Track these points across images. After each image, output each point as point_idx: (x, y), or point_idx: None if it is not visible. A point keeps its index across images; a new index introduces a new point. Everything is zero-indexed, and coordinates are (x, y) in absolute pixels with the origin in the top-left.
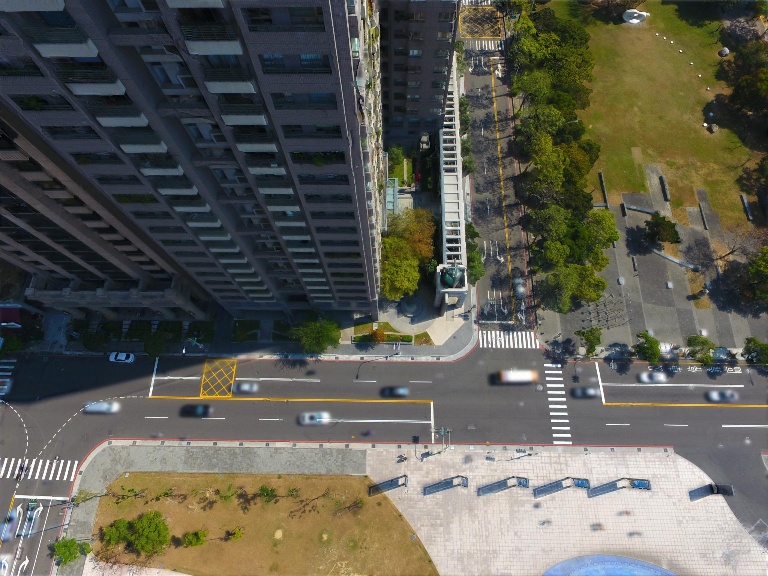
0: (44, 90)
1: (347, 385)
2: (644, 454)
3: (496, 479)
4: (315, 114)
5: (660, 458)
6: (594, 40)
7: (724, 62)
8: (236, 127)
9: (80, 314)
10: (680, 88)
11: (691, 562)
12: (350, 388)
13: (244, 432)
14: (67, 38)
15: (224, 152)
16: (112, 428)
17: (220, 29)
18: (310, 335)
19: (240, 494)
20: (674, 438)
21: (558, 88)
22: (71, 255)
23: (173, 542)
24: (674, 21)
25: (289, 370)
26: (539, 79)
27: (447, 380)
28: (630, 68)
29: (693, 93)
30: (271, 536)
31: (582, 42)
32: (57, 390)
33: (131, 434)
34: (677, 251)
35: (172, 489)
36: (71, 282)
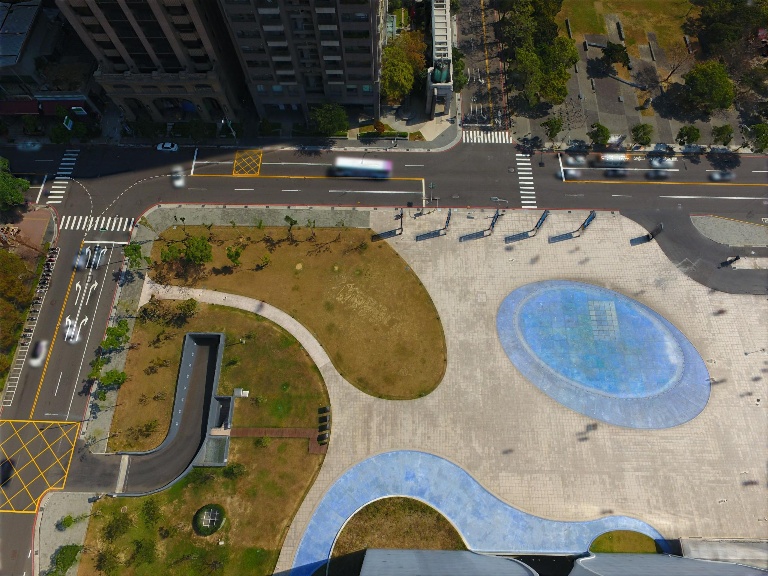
0: None
1: (354, 167)
2: None
3: (475, 231)
4: None
5: (608, 218)
6: None
7: None
8: None
9: (132, 115)
10: None
11: (629, 285)
12: (356, 170)
13: (270, 199)
14: None
15: None
16: (161, 196)
17: None
18: (324, 114)
19: (267, 240)
20: (620, 204)
21: None
22: (137, 26)
23: (214, 271)
24: None
25: (306, 157)
26: None
27: (436, 164)
28: None
29: None
30: (293, 268)
31: None
32: (114, 171)
33: (177, 200)
34: (629, 76)
35: None
36: (130, 70)
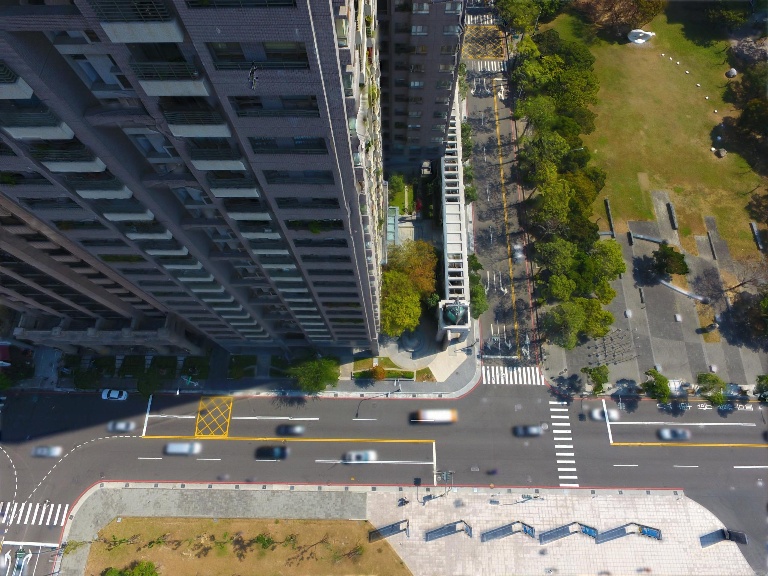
0: (18, 168)
1: (346, 424)
2: (653, 497)
3: (500, 524)
4: (311, 187)
5: (670, 501)
6: (599, 61)
7: (732, 83)
8: (226, 198)
9: (72, 349)
10: (687, 111)
11: None
12: (350, 427)
13: (240, 474)
14: (39, 122)
15: (216, 212)
16: (104, 470)
17: (206, 114)
18: (308, 375)
19: (236, 540)
20: (684, 480)
21: (562, 112)
22: (60, 298)
23: None
24: (680, 41)
25: (287, 408)
26: (544, 106)
27: (450, 418)
28: (636, 90)
29: (700, 116)
30: None
31: (587, 65)
32: (48, 429)
33: (124, 476)
34: (685, 282)
35: (165, 536)
36: (61, 320)
